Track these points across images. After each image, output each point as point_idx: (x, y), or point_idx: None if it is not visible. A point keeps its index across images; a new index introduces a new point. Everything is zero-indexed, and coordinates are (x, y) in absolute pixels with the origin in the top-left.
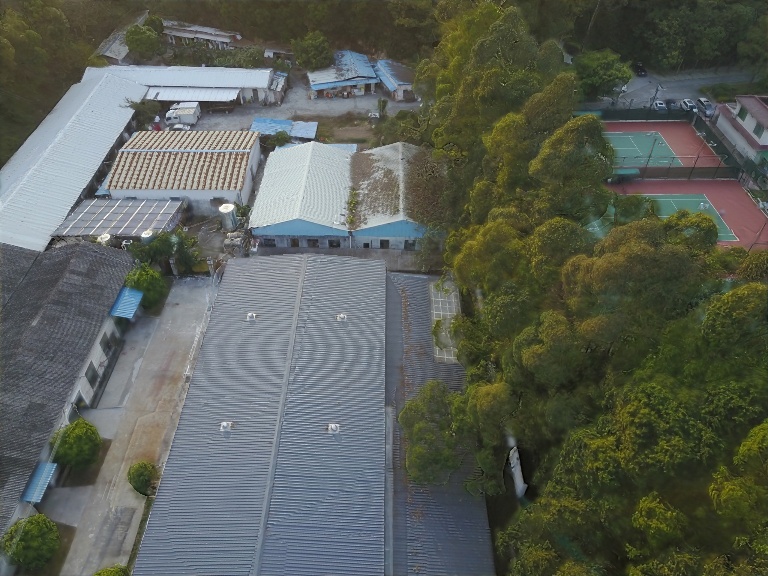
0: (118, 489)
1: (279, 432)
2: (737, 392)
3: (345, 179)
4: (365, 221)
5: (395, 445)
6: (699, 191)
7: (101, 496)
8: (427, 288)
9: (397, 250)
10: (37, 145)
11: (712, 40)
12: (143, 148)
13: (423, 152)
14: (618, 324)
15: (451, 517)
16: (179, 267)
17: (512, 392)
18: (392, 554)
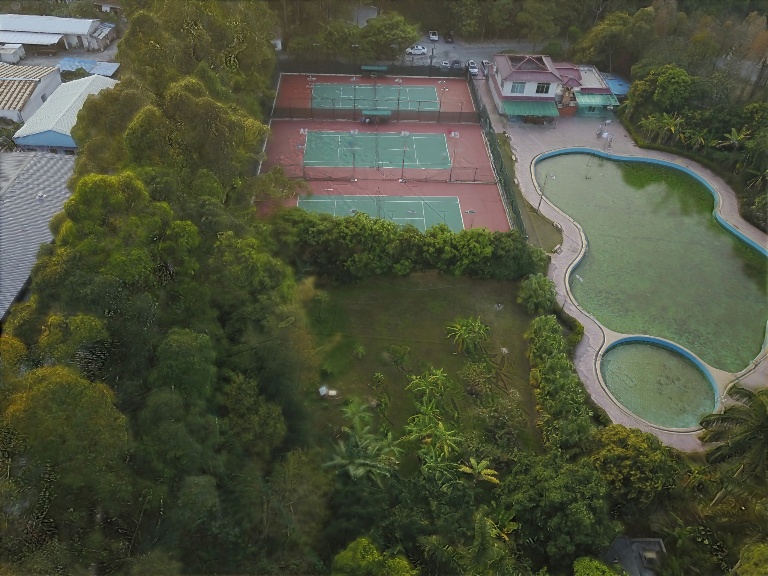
0: None
1: None
2: None
3: None
4: None
5: None
6: (442, 132)
7: None
8: None
9: None
10: None
11: (502, 11)
12: None
13: None
14: (97, 146)
15: None
16: None
17: None
18: None
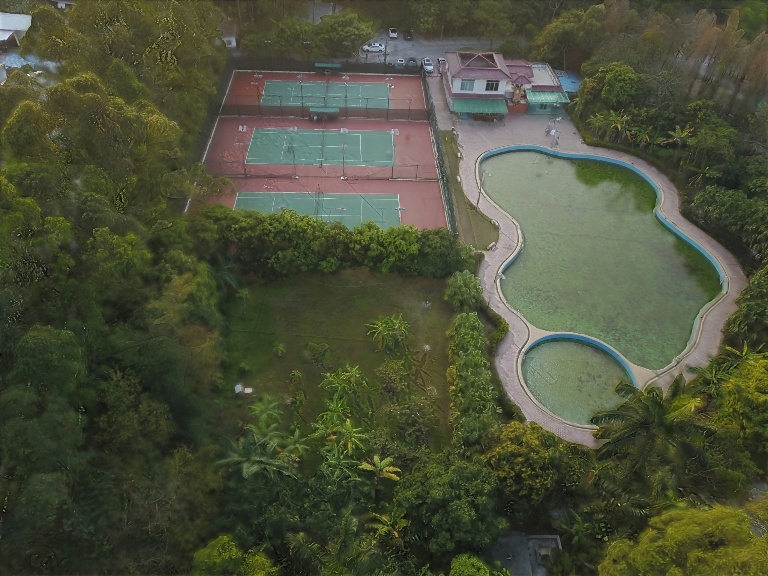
0: None
1: None
2: (2, 173)
3: None
4: None
5: None
6: (390, 129)
7: None
8: None
9: None
10: None
11: (459, 8)
12: None
13: None
14: None
15: None
16: None
17: None
18: None
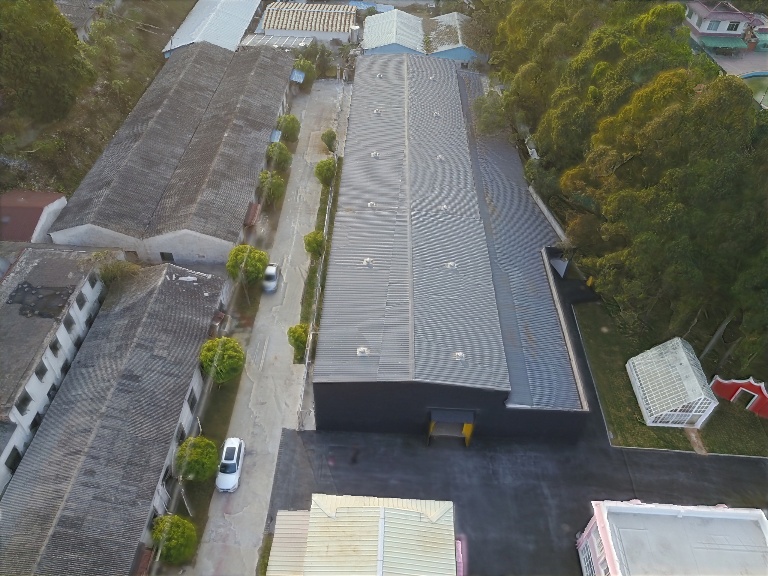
0: (309, 156)
1: (408, 113)
2: None
3: (420, 30)
4: (437, 49)
5: (468, 130)
6: None
7: (300, 158)
8: (479, 78)
9: (457, 67)
10: (207, 5)
11: None
12: (282, 8)
13: (471, 19)
14: (589, 10)
15: (500, 154)
16: (317, 71)
17: (537, 65)
18: (471, 161)
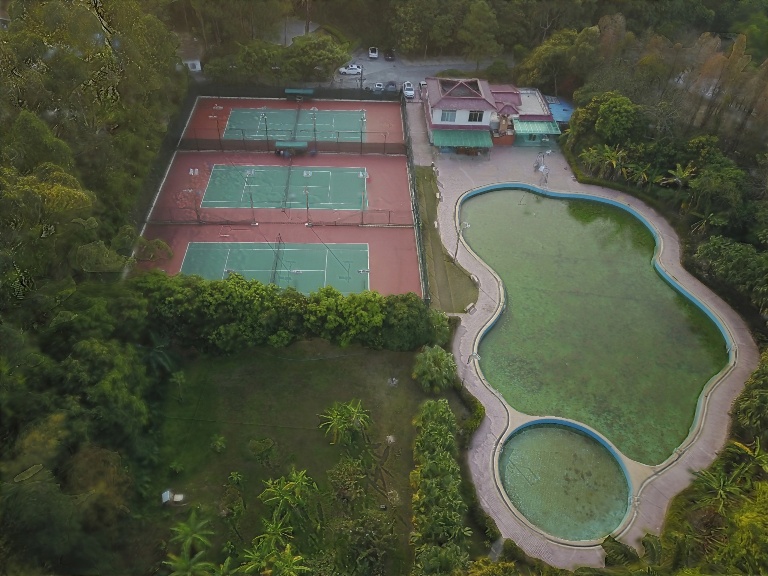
0: None
1: None
2: None
3: None
4: None
5: None
6: (363, 165)
7: None
8: None
9: None
10: None
11: (443, 27)
12: None
13: None
14: None
15: None
16: None
17: None
18: None
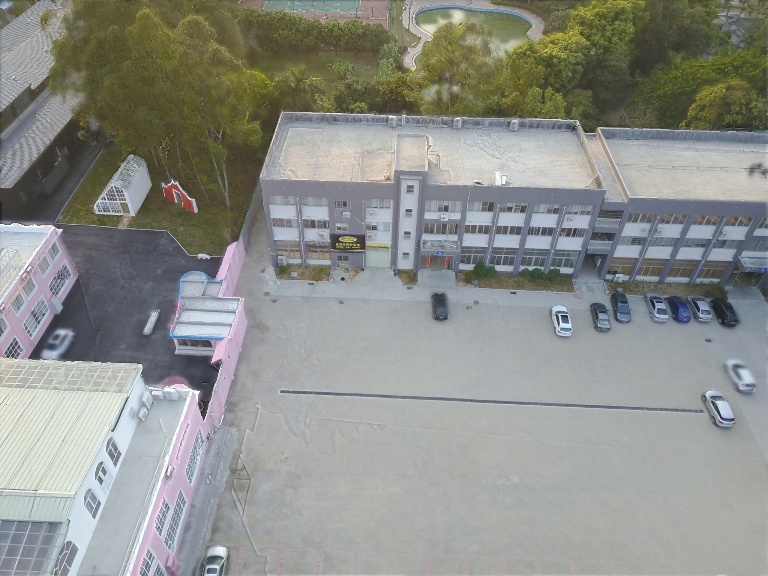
0: None
1: None
2: None
3: None
4: None
5: None
6: None
7: None
8: None
9: None
10: None
11: None
12: None
13: None
14: None
15: None
16: None
17: None
18: None
